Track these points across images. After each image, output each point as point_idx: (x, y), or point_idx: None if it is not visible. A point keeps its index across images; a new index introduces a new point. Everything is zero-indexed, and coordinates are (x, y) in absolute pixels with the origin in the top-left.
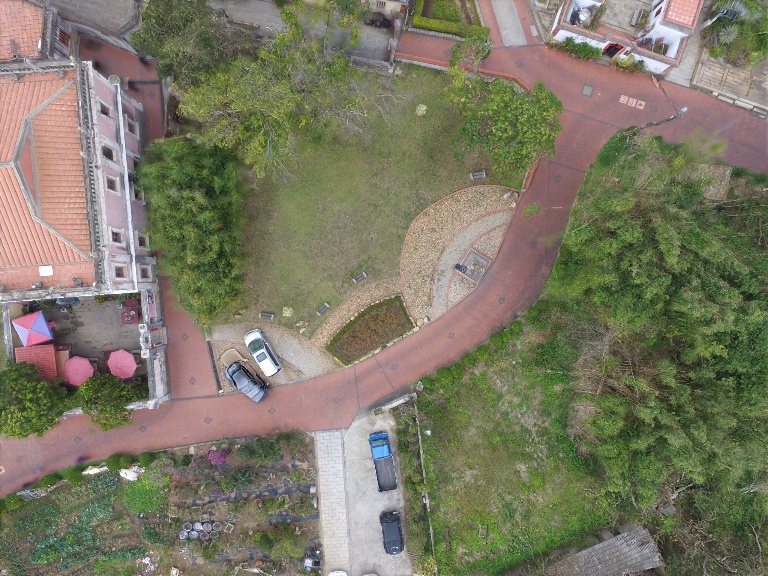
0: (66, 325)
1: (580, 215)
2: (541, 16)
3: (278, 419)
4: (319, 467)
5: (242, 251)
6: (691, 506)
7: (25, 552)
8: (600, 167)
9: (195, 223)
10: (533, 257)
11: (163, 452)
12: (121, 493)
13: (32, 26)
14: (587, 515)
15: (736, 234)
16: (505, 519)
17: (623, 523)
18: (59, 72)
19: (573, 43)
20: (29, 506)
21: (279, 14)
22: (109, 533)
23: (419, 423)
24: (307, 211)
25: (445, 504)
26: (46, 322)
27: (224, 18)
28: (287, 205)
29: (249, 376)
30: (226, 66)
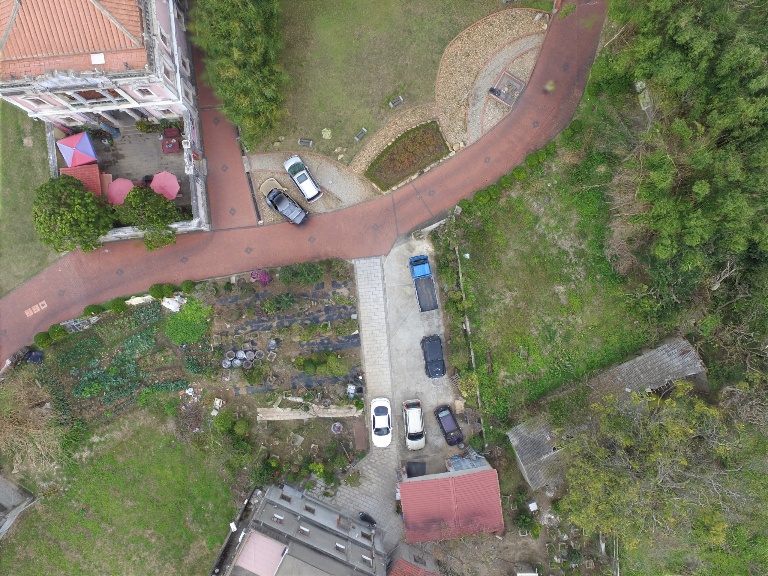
0: (107, 158)
1: (610, 35)
2: None
3: (318, 248)
4: (359, 294)
5: (280, 78)
6: (730, 312)
7: (68, 386)
8: None
9: (241, 18)
10: (565, 80)
11: (205, 282)
12: (163, 325)
13: None
14: (626, 334)
15: (767, 27)
16: (545, 341)
17: (663, 338)
18: None
19: None
20: (72, 339)
21: None
22: (152, 365)
23: (458, 247)
24: (343, 38)
25: (486, 326)
26: (90, 143)
27: None
28: (323, 33)
29: (289, 200)
30: None
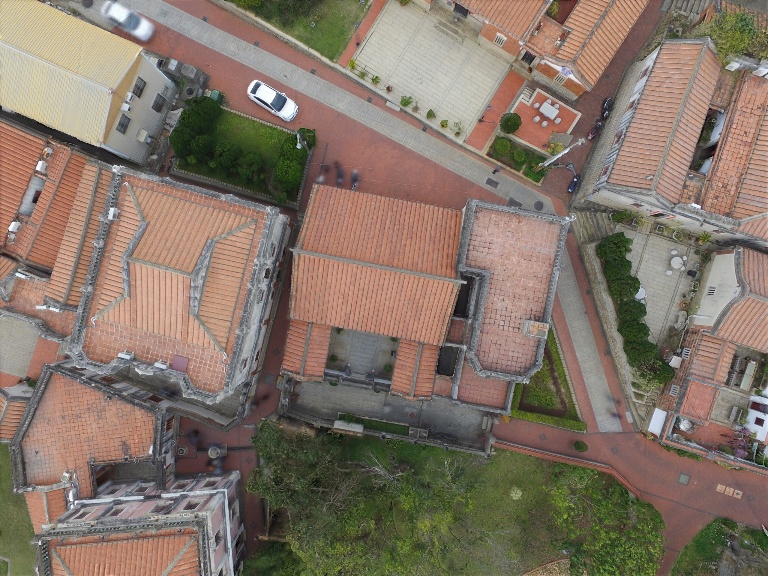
0: None
1: None
2: (637, 407)
3: None
4: None
5: None
6: None
7: None
8: (696, 552)
9: None
10: None
11: None
12: None
13: (143, 428)
14: None
15: None
16: None
17: None
18: (181, 528)
19: (673, 448)
20: None
21: (375, 393)
22: None
23: None
24: None
25: None
26: None
27: (322, 397)
28: None
29: None
30: (341, 522)
